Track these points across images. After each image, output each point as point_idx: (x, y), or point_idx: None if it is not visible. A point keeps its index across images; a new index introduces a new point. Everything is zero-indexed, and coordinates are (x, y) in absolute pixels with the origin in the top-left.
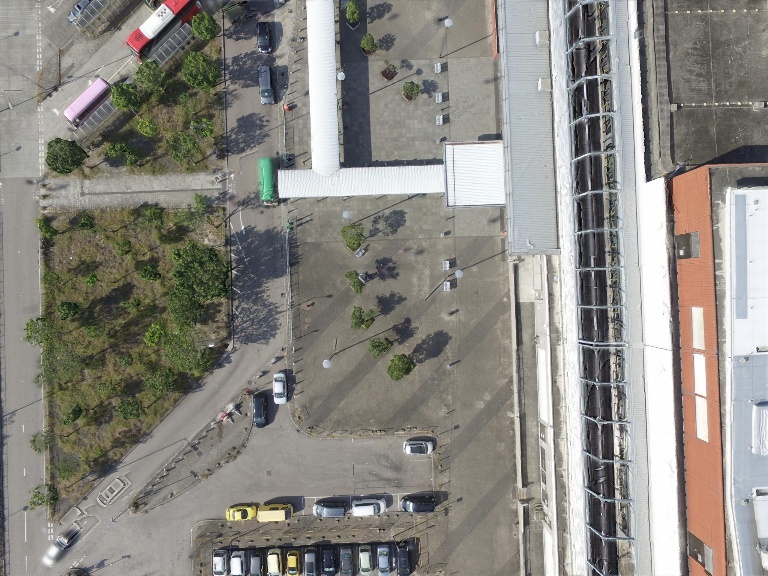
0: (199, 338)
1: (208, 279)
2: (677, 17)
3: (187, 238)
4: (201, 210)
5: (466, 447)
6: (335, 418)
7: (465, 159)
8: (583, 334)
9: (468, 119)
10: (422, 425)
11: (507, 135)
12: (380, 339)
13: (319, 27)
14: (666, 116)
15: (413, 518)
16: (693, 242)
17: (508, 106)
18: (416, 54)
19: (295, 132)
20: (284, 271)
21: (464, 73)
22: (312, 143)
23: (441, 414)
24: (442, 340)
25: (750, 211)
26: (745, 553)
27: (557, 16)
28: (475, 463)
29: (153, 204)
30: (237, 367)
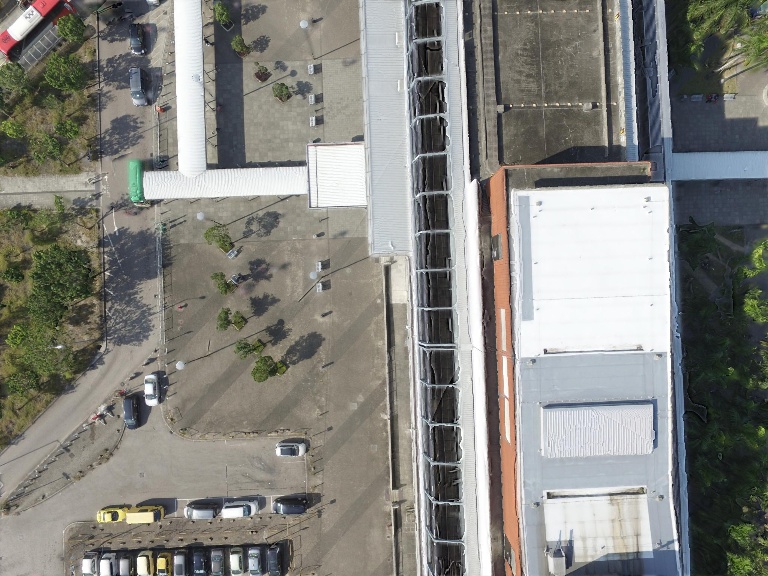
0: (72, 340)
1: (65, 280)
2: (507, 18)
3: (60, 239)
4: (74, 211)
5: (339, 449)
6: (208, 420)
7: (328, 160)
8: (432, 336)
9: (342, 120)
10: (295, 427)
11: (367, 136)
12: (247, 341)
13: (186, 29)
14: (493, 117)
15: (286, 520)
16: (499, 243)
17: (368, 107)
18: (290, 55)
19: (169, 133)
20: (157, 272)
21: (338, 74)
22: (178, 144)
23: (314, 416)
24: (315, 342)
25: (534, 212)
26: (532, 556)
27: (403, 17)
28: (348, 465)
29: (26, 206)
30: (110, 369)
